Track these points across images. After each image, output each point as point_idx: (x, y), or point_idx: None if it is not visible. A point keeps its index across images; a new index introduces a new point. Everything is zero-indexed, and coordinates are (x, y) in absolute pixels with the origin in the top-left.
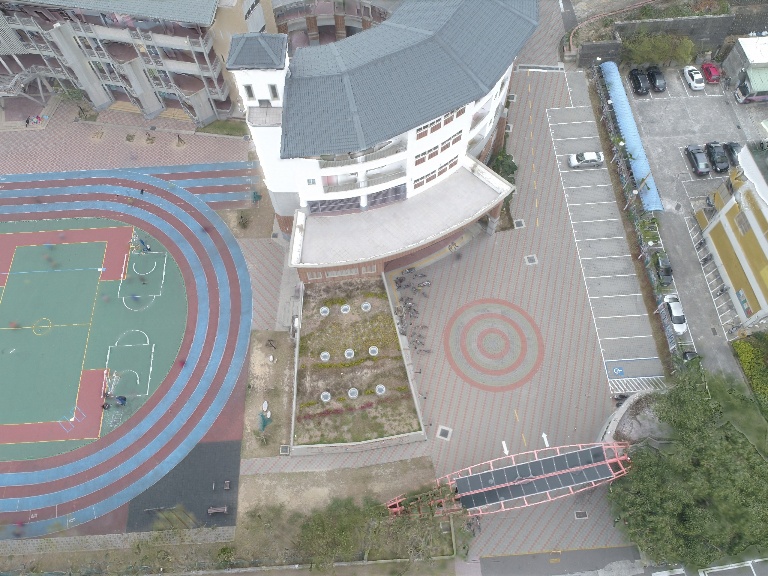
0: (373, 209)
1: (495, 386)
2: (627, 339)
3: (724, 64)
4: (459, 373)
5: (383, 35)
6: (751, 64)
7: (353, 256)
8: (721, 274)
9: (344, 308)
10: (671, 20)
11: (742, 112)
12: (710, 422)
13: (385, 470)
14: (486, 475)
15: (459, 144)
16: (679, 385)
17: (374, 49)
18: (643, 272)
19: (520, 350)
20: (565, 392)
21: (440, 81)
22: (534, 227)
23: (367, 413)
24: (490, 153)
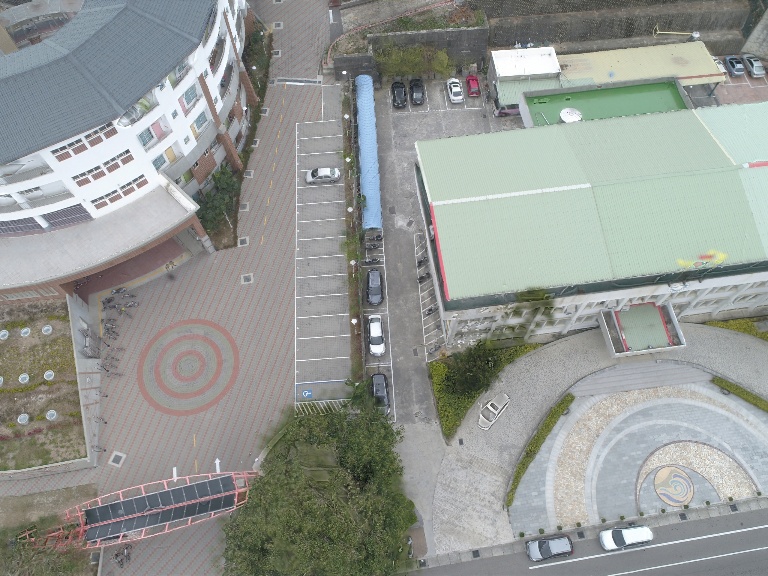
0: (57, 230)
1: (180, 410)
2: (324, 360)
3: (487, 76)
4: (146, 397)
5: (31, 54)
6: (498, 77)
7: (24, 279)
8: (435, 293)
9: (25, 331)
10: (424, 32)
11: (497, 125)
12: (389, 446)
13: (48, 498)
14: (115, 505)
15: (136, 164)
16: (342, 410)
17: (9, 69)
18: (354, 291)
19: (214, 372)
20: (249, 416)
21: (70, 102)
22: (257, 245)
23: (36, 439)
24: (227, 169)
